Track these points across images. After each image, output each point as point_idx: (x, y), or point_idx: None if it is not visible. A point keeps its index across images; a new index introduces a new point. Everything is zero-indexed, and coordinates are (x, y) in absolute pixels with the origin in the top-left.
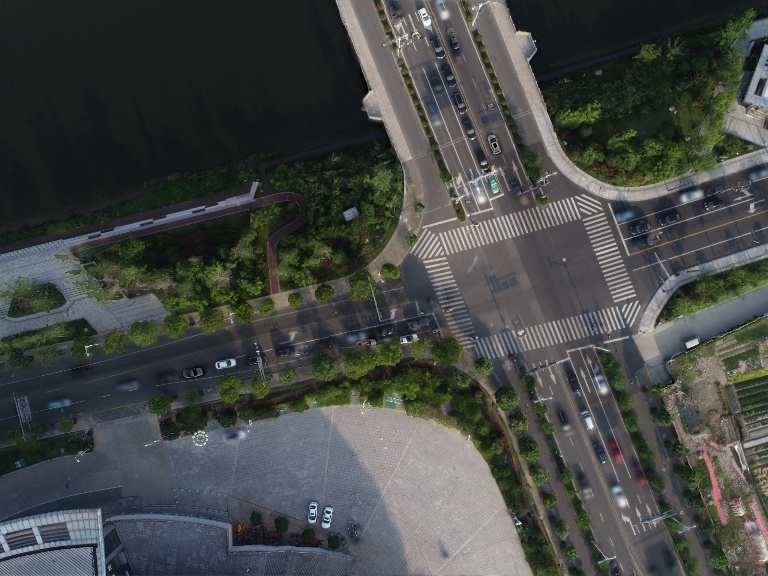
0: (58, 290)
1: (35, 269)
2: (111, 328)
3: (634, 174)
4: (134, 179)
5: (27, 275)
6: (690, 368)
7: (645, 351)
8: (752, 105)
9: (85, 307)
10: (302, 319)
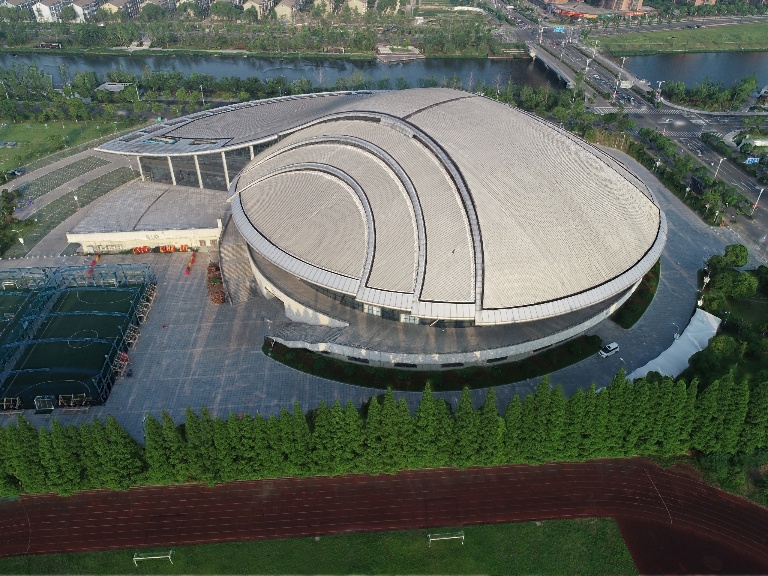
0: None
1: None
2: None
3: (706, 102)
4: None
5: None
6: (760, 151)
7: (729, 144)
8: (765, 101)
9: None
10: None
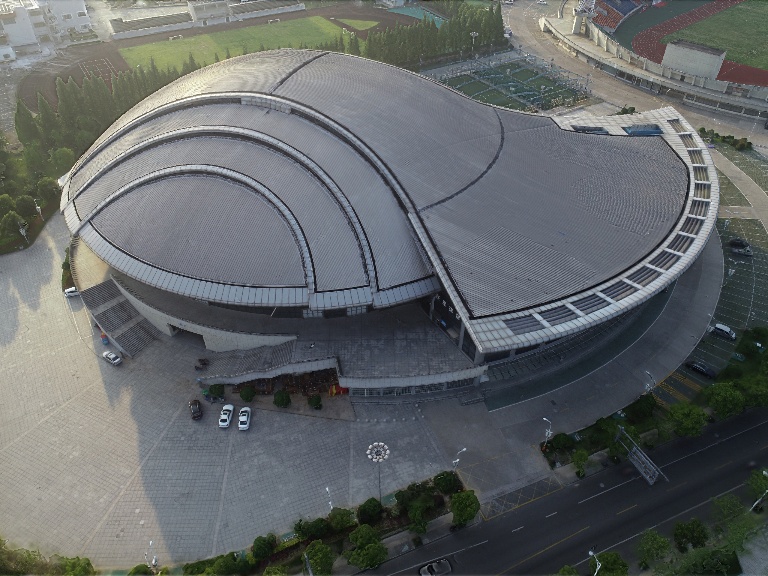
0: None
1: None
2: None
3: None
4: None
5: None
6: None
7: None
8: None
9: None
10: None
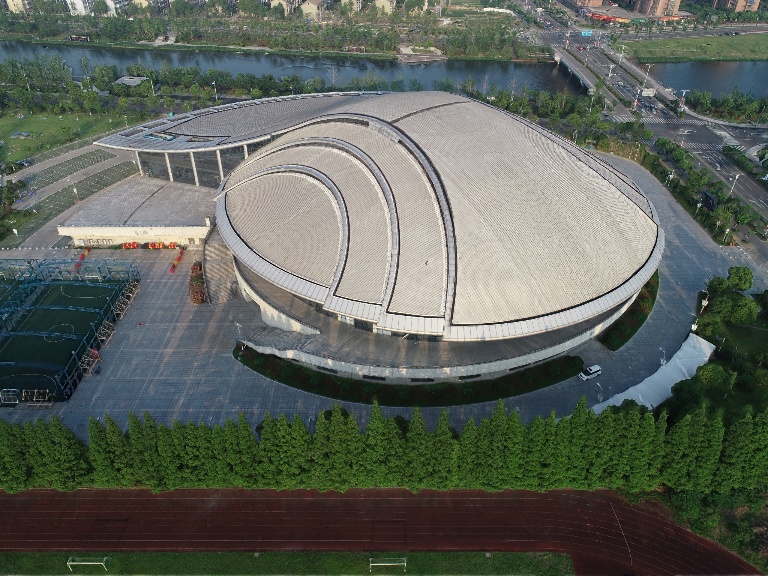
0: None
1: None
2: None
3: (733, 113)
4: None
5: None
6: None
7: (752, 158)
8: None
9: None
10: (542, 124)
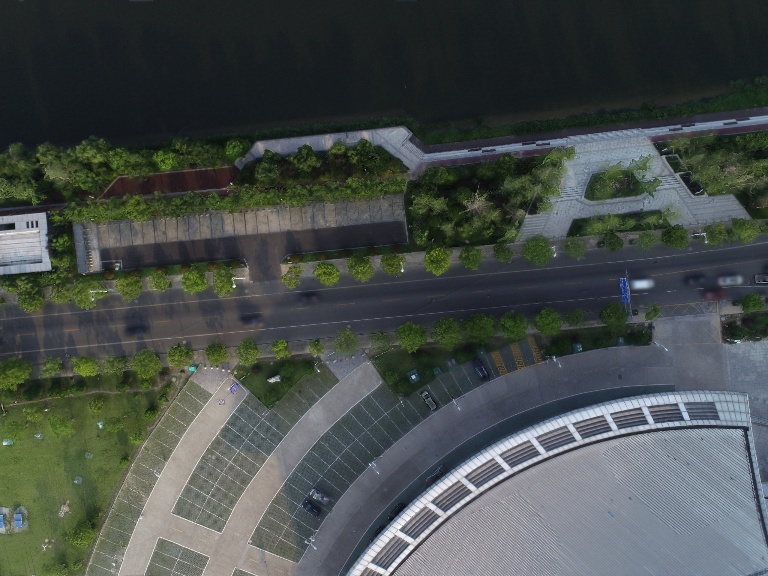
0: (636, 178)
1: (613, 154)
2: (686, 223)
3: None
4: (719, 77)
5: (604, 159)
6: None
7: None
8: None
9: (662, 199)
10: None
